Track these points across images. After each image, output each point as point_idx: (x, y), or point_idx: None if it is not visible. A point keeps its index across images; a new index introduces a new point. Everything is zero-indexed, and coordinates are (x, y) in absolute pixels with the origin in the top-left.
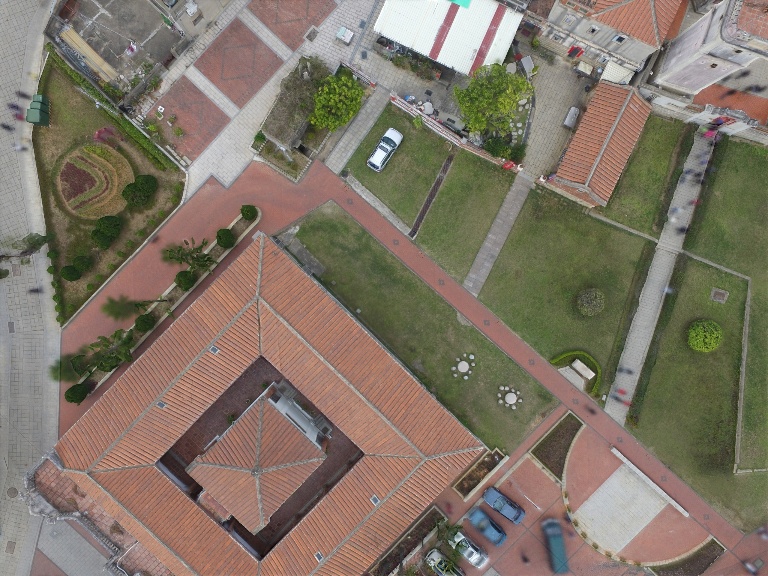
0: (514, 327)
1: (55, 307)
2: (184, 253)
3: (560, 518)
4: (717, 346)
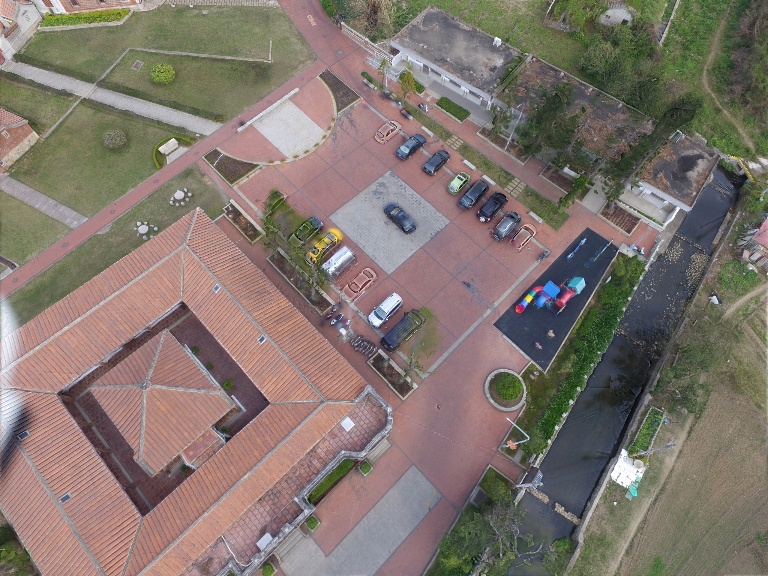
0: (123, 193)
1: None
2: None
3: (292, 168)
4: (170, 66)
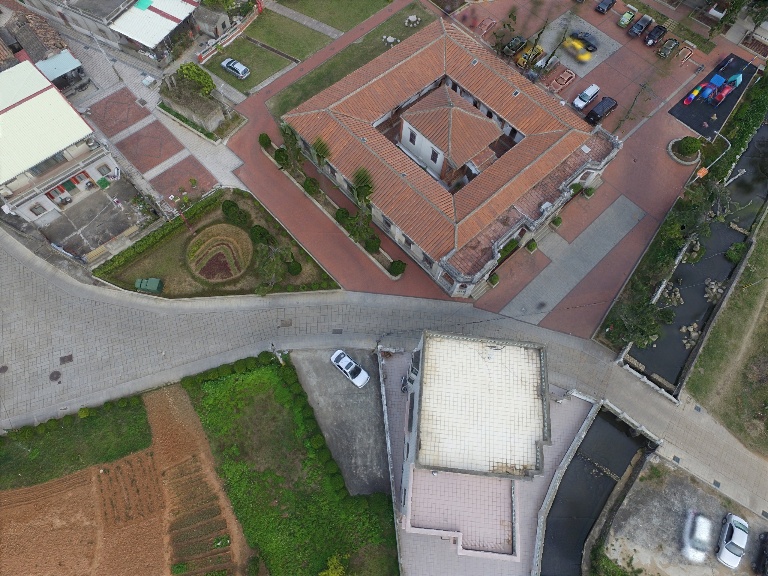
0: (366, 17)
1: (322, 286)
2: (287, 133)
3: (493, 6)
4: None
